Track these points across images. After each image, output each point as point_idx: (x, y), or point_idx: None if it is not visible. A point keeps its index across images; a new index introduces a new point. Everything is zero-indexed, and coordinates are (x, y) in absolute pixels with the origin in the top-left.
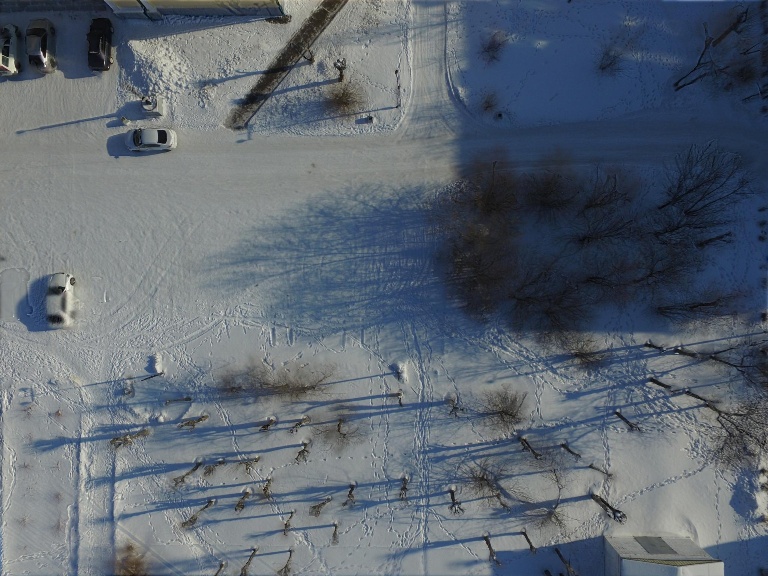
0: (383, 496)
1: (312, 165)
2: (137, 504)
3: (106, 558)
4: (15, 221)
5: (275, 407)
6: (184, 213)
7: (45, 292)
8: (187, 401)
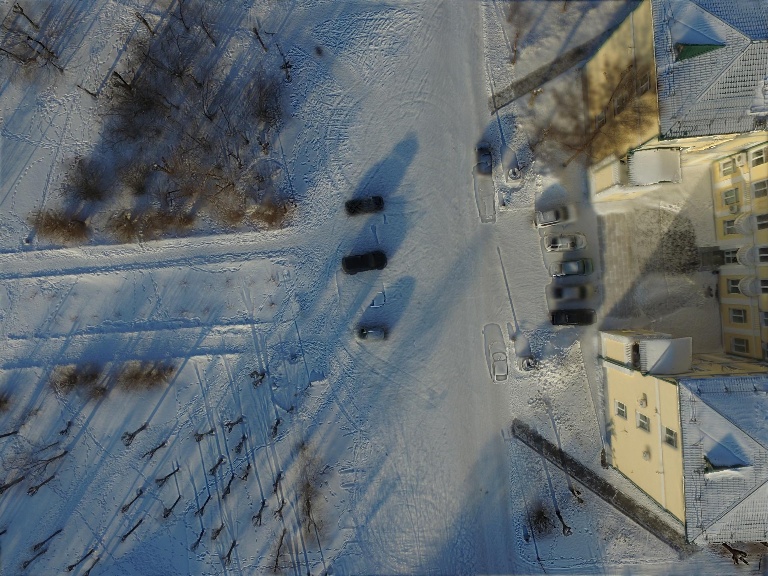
0: (229, 567)
1: (487, 491)
2: (205, 371)
3: (161, 351)
4: (425, 252)
5: (291, 477)
6: (441, 391)
7: (369, 283)
8: (290, 408)
